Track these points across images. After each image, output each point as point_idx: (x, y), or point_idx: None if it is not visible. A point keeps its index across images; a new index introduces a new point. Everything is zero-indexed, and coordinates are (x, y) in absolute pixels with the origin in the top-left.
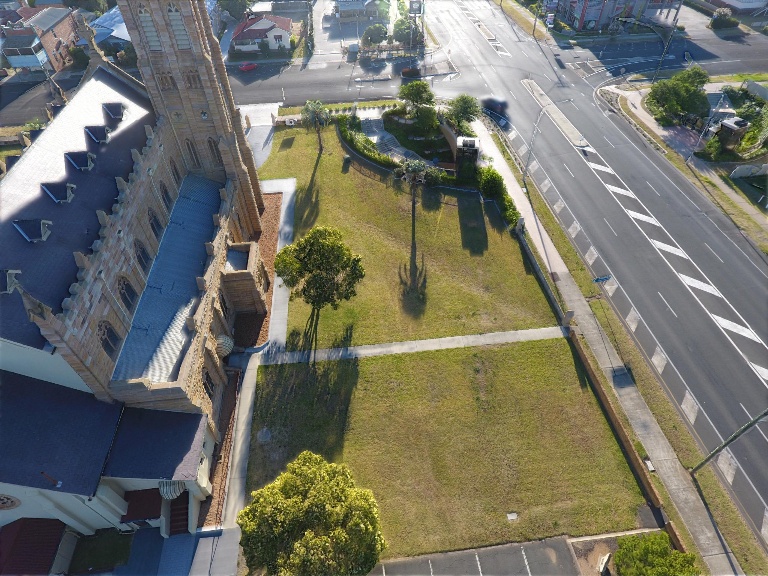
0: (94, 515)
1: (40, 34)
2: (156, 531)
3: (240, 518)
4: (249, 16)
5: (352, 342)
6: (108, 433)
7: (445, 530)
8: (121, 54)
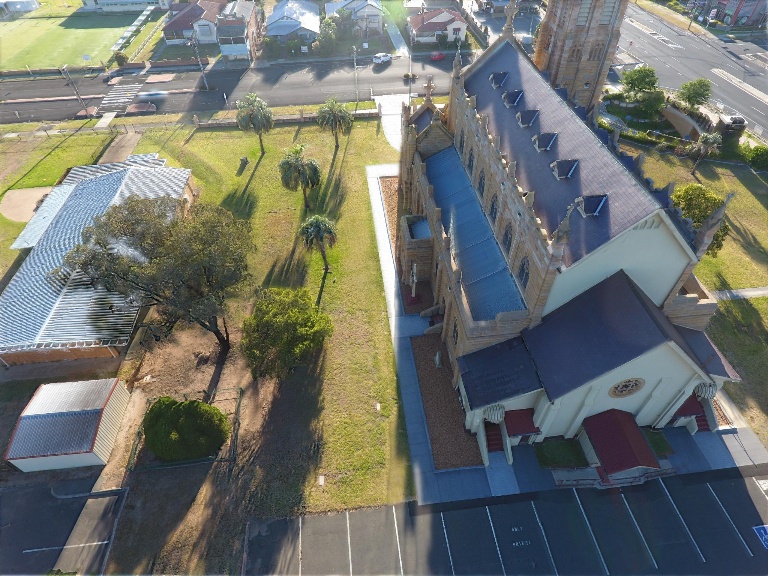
0: (655, 410)
1: (247, 24)
2: (679, 430)
3: None
4: (420, 10)
5: (731, 286)
6: (682, 338)
7: None
8: (316, 44)
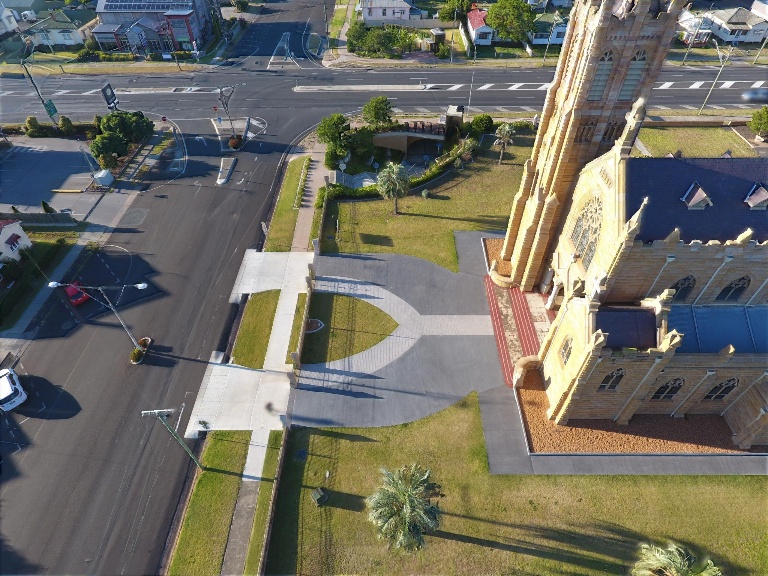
0: None
1: None
2: None
3: None
4: None
5: None
6: None
7: None
8: None
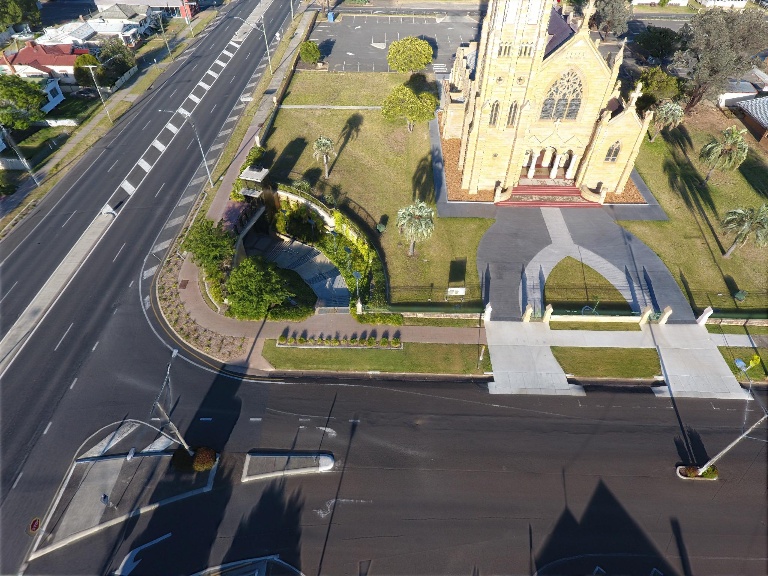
0: None
1: None
2: None
3: None
4: None
5: None
6: None
7: (366, 74)
8: None
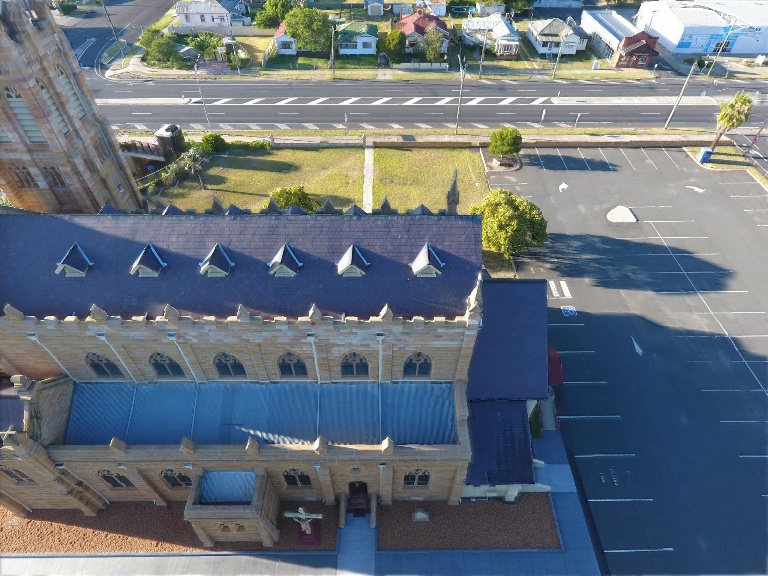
0: None
1: None
2: None
3: (508, 235)
4: None
5: None
6: None
7: None
8: None
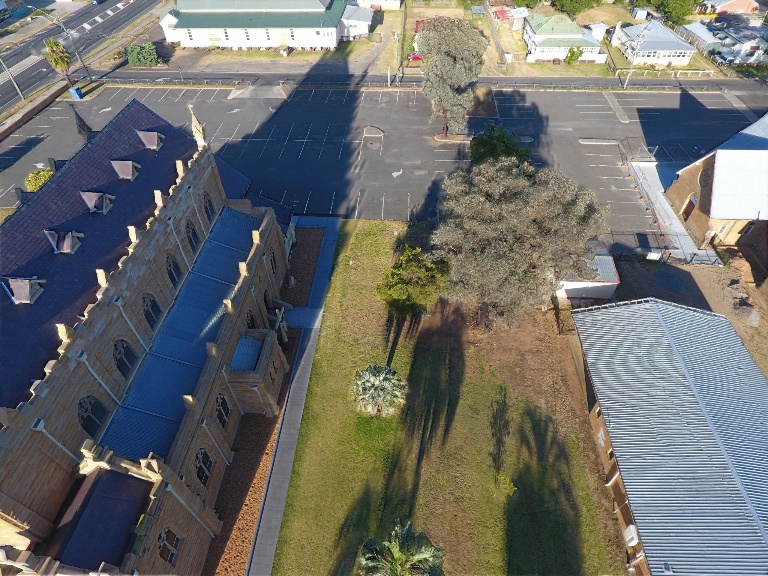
0: None
1: None
2: None
3: None
4: None
5: None
6: None
7: None
8: None
